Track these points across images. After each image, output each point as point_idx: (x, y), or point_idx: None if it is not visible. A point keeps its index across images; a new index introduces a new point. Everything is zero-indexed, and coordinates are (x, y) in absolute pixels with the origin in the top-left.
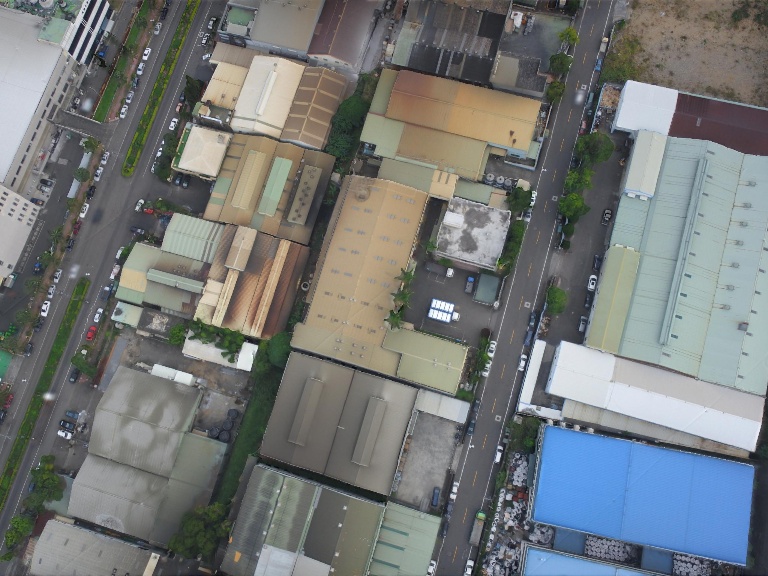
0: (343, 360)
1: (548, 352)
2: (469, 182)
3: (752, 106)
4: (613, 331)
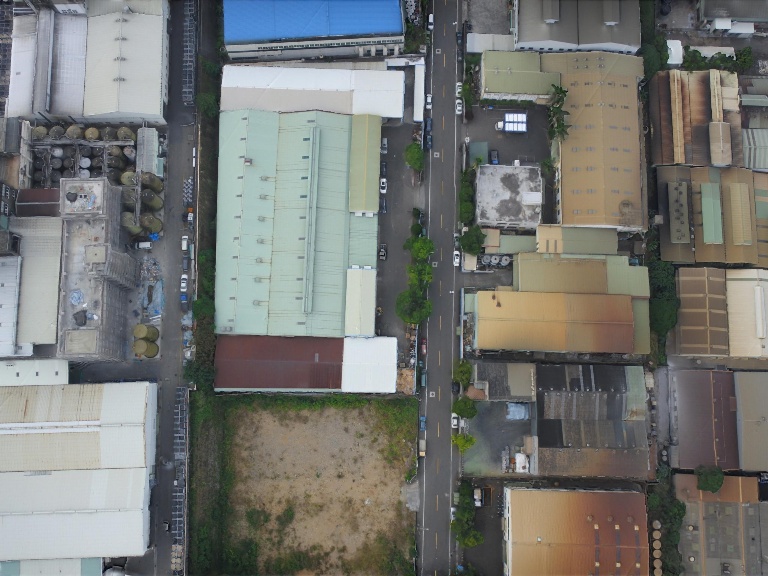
0: (592, 52)
1: (409, 116)
2: (525, 251)
3: (266, 390)
4: (361, 132)
